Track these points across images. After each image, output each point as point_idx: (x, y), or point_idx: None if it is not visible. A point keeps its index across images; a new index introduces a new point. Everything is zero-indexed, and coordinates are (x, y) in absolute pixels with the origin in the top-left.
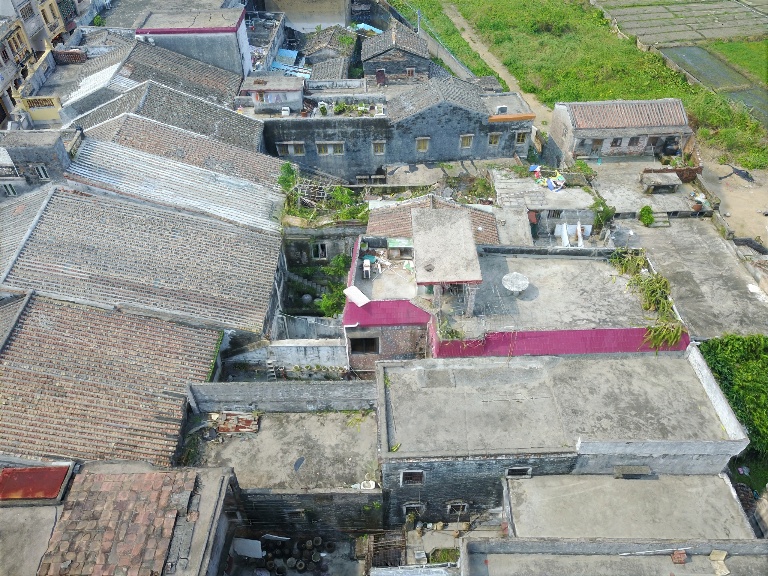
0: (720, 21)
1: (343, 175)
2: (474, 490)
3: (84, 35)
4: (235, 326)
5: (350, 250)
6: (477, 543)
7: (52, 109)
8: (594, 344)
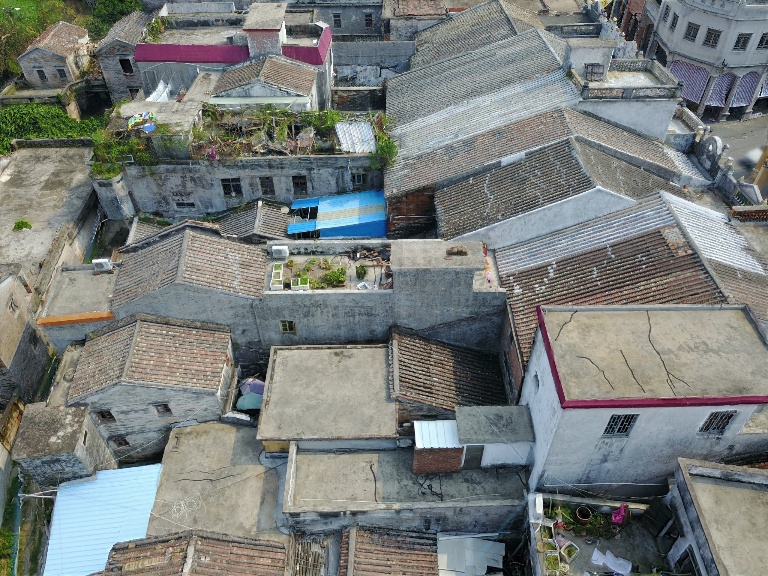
0: None
1: None
2: None
3: None
4: None
5: None
6: None
7: None
8: (203, 24)
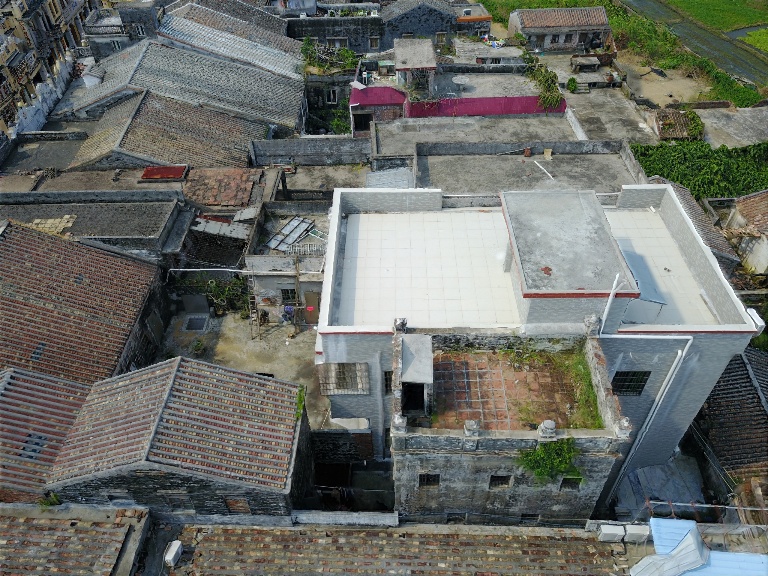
0: None
1: None
2: None
3: None
4: (277, 122)
5: None
6: (422, 146)
7: None
8: (507, 107)
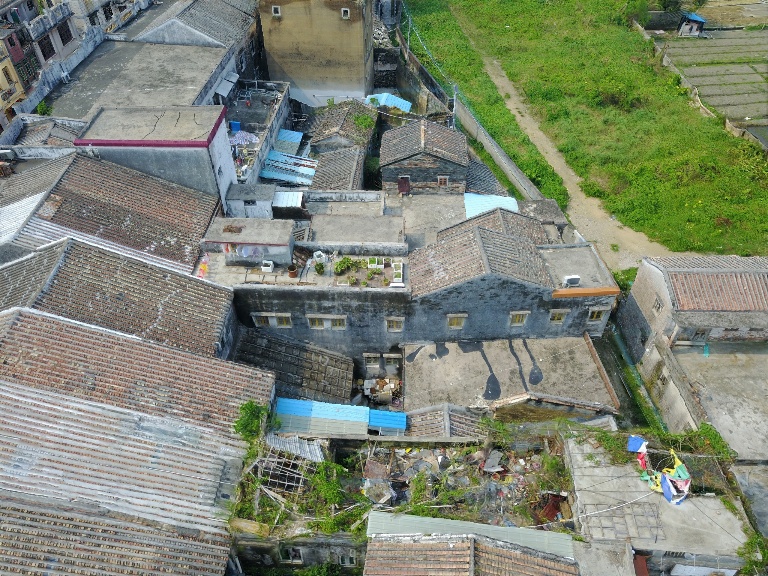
0: None
1: (344, 351)
2: None
3: (25, 124)
4: None
5: (338, 558)
6: None
7: None
8: None
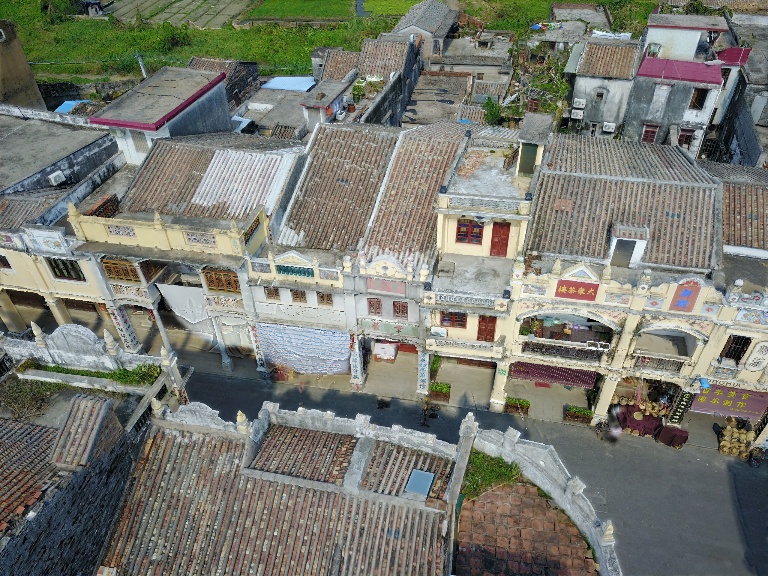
0: (214, 5)
1: None
2: None
3: None
4: None
5: None
6: None
7: (259, 230)
8: None
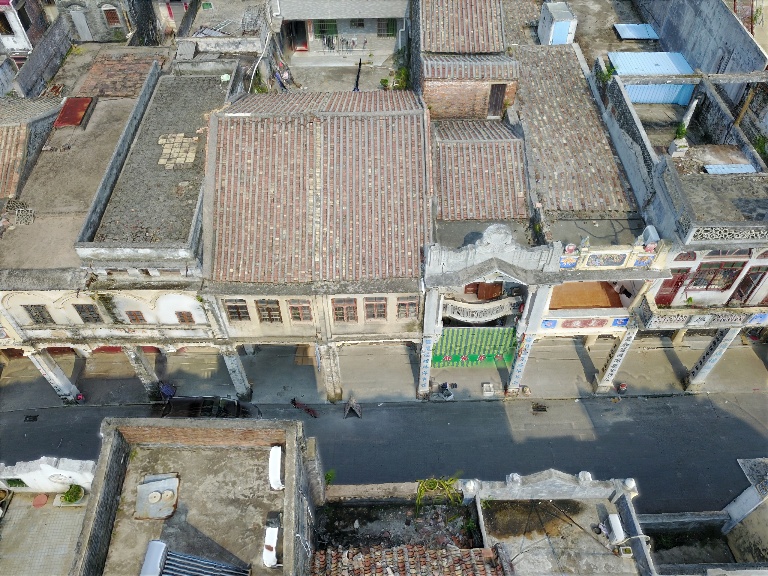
0: None
1: None
2: (147, 8)
3: None
4: None
5: None
6: None
7: None
8: None
